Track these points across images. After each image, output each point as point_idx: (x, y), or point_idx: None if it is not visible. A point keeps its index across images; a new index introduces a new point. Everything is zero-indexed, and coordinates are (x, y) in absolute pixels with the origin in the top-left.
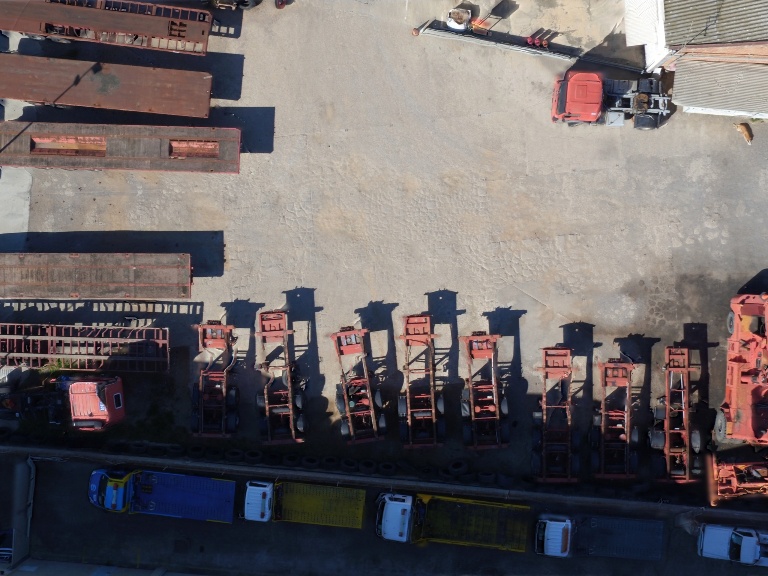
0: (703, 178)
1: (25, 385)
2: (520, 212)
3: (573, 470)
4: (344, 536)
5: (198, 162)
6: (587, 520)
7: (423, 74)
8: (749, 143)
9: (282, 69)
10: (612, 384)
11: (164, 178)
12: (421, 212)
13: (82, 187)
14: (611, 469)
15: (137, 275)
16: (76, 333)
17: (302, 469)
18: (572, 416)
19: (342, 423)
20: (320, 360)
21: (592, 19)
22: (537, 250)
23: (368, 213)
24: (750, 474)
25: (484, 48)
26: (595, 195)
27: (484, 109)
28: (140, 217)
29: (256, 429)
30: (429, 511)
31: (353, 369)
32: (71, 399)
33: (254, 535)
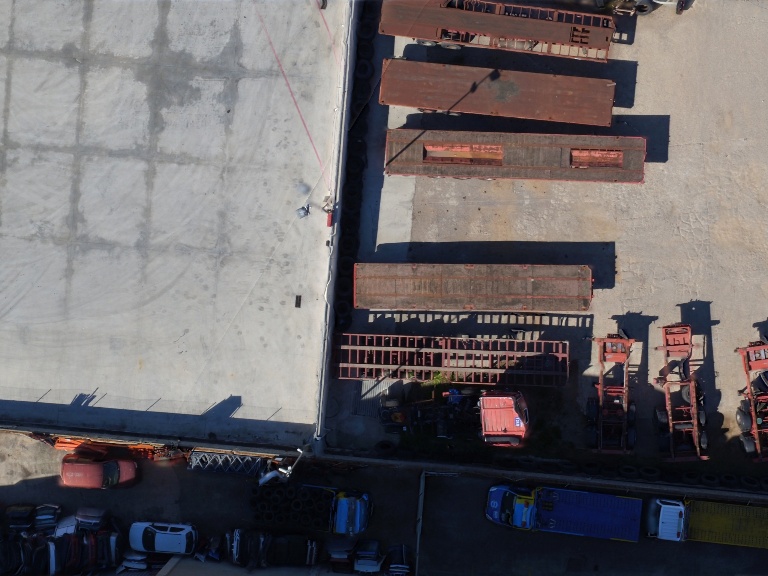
0: None
1: (411, 398)
2: None
3: None
4: (750, 556)
5: (601, 172)
6: None
7: None
8: None
9: (678, 76)
10: None
11: (557, 188)
12: None
13: (466, 196)
14: None
15: (535, 287)
16: (470, 346)
17: (705, 487)
18: None
19: (747, 440)
20: (716, 375)
21: None
22: None
23: (767, 224)
24: None
25: None
26: None
27: None
28: (527, 227)
29: (654, 445)
30: None
31: (751, 384)
32: (483, 414)
33: (658, 554)
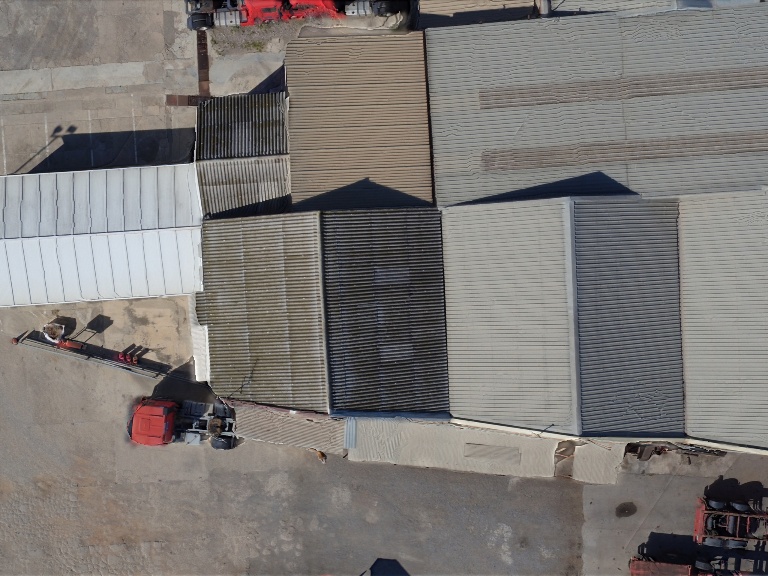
0: (280, 493)
1: None
2: (109, 518)
3: None
4: None
5: None
6: None
7: (21, 382)
8: (323, 462)
9: None
10: None
11: None
12: (15, 514)
13: None
14: None
15: None
16: None
17: None
18: None
19: None
20: None
21: (180, 338)
22: (124, 555)
23: None
24: None
25: (78, 361)
26: (179, 505)
27: (77, 418)
28: None
29: None
30: None
31: None
32: None
33: None
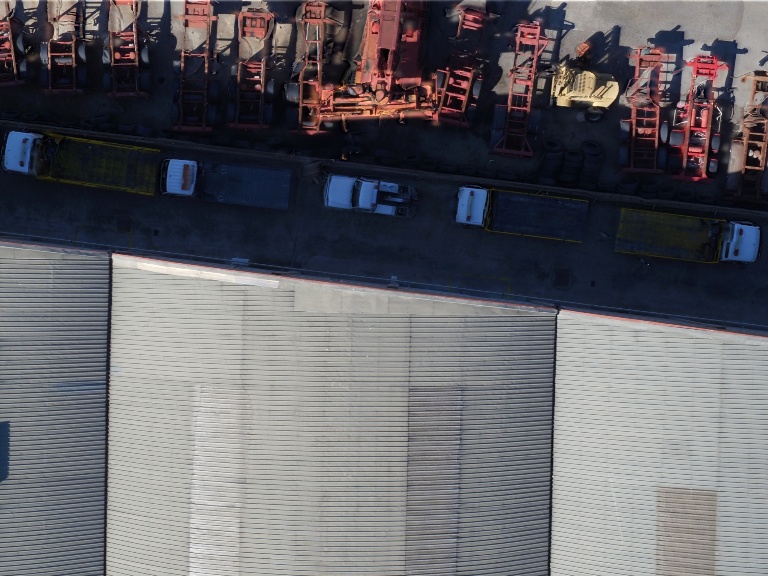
0: None
1: None
2: None
3: (208, 119)
4: None
5: None
6: (218, 167)
7: None
8: None
9: None
10: (250, 34)
11: None
12: None
13: None
14: (246, 119)
15: None
16: None
17: None
18: (217, 73)
19: None
20: None
21: None
22: None
23: None
24: (347, 92)
25: None
26: None
27: None
28: None
29: None
30: (60, 151)
31: None
32: None
33: None
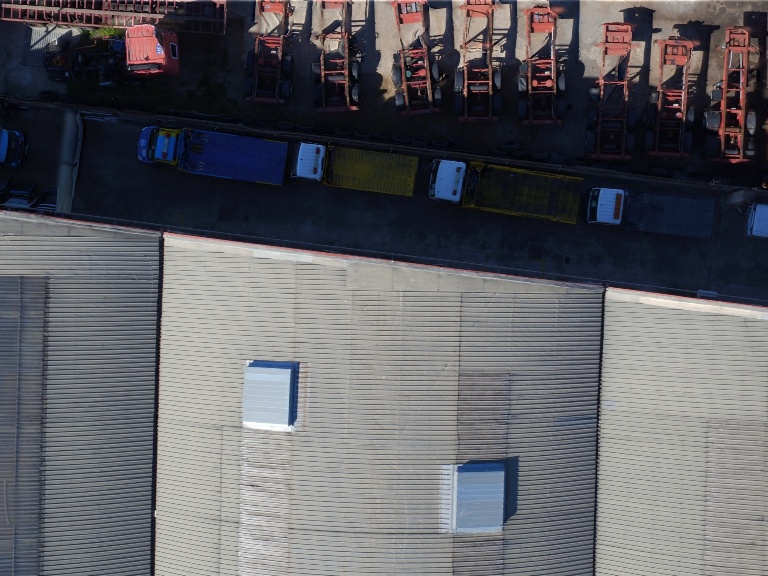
0: None
1: (76, 46)
2: None
3: (627, 147)
4: (394, 206)
5: None
6: (639, 195)
7: None
8: None
9: None
10: (671, 62)
11: None
12: None
13: None
14: (665, 148)
15: None
16: None
17: (355, 138)
18: None
19: (397, 94)
20: (377, 36)
21: None
22: None
23: None
24: None
25: None
26: None
27: None
28: None
29: (309, 99)
30: (482, 179)
31: (410, 46)
32: (127, 43)
33: (303, 200)
